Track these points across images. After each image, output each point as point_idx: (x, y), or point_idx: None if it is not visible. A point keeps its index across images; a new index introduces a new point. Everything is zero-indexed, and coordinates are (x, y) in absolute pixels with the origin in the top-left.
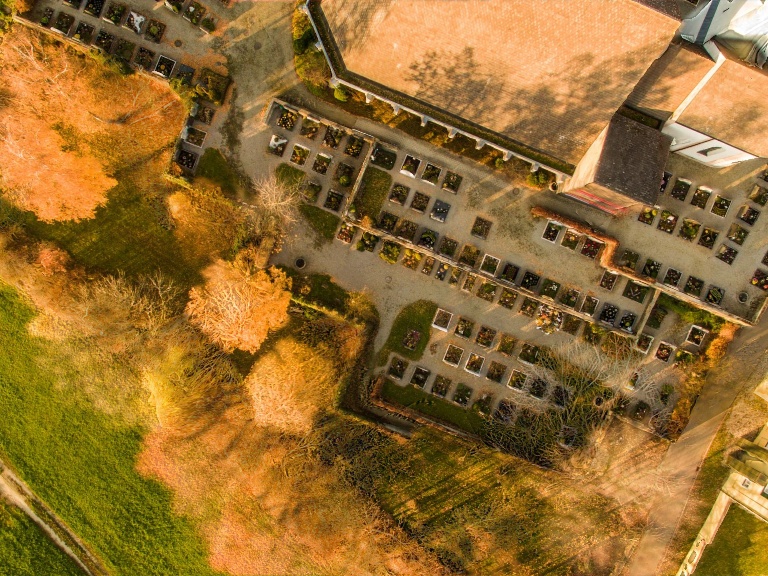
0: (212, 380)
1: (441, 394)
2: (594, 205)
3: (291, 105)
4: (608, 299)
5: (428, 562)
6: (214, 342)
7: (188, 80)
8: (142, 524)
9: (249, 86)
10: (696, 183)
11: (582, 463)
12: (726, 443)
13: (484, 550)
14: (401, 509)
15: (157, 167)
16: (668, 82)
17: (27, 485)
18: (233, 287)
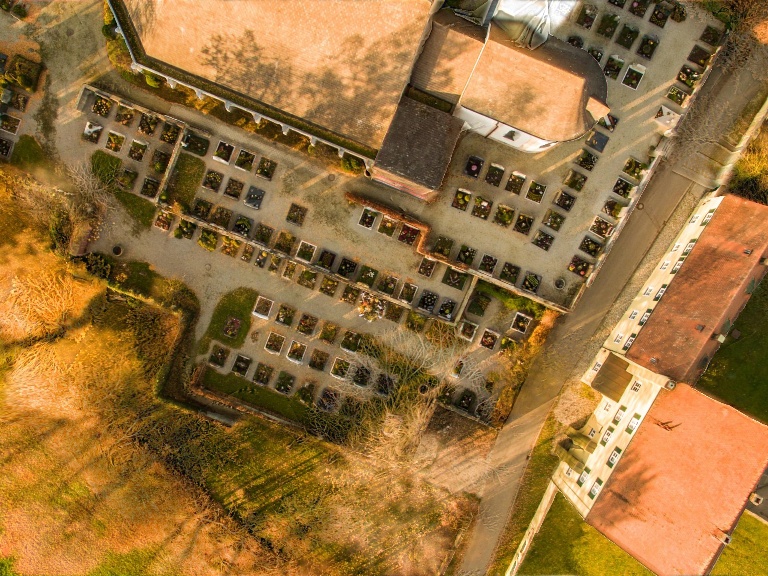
0: (35, 368)
1: (262, 382)
2: (405, 191)
3: (102, 91)
4: (427, 286)
5: (259, 551)
6: (38, 330)
7: (0, 67)
8: None
9: (62, 73)
10: (510, 168)
11: (406, 451)
12: (555, 431)
13: (315, 539)
14: (231, 498)
15: None
16: (447, 64)
17: None
18: (56, 275)
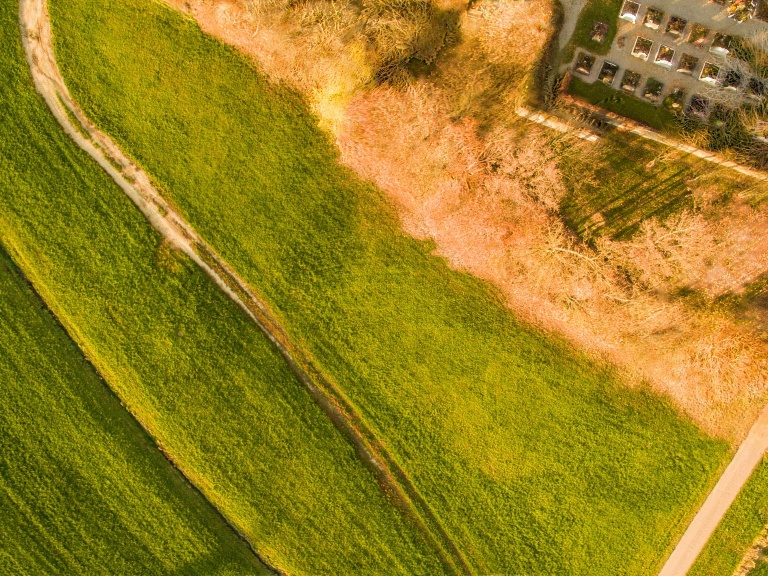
0: (390, 88)
1: (632, 87)
2: None
3: None
4: None
5: (615, 280)
6: (389, 51)
7: None
8: (309, 265)
9: None
10: None
11: None
12: None
13: (674, 265)
14: (586, 224)
15: None
16: None
17: (192, 228)
18: None
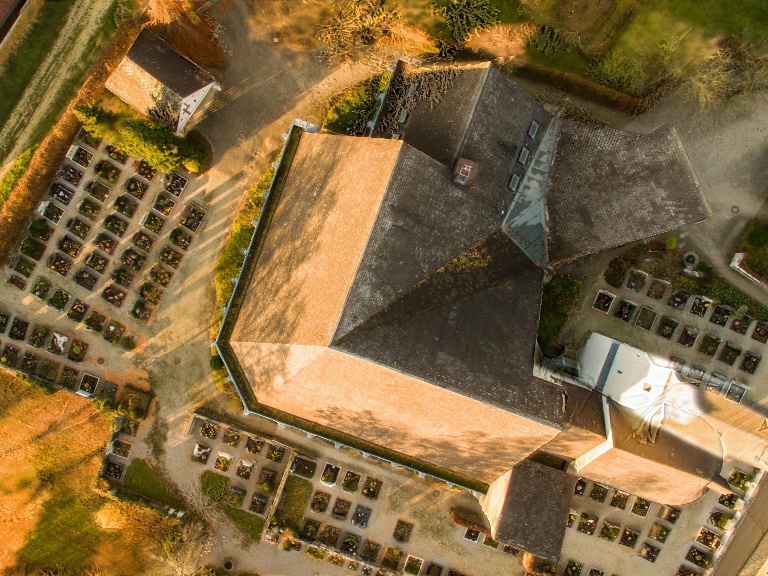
0: None
1: None
2: None
3: (211, 420)
4: None
5: None
6: None
7: (112, 396)
8: None
9: (171, 399)
10: None
11: None
12: None
13: None
14: None
15: (89, 470)
16: (565, 442)
17: None
18: None
